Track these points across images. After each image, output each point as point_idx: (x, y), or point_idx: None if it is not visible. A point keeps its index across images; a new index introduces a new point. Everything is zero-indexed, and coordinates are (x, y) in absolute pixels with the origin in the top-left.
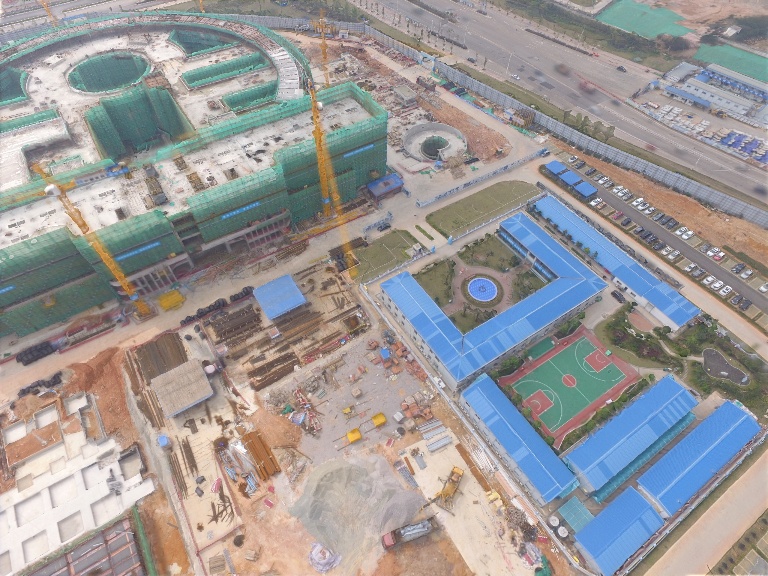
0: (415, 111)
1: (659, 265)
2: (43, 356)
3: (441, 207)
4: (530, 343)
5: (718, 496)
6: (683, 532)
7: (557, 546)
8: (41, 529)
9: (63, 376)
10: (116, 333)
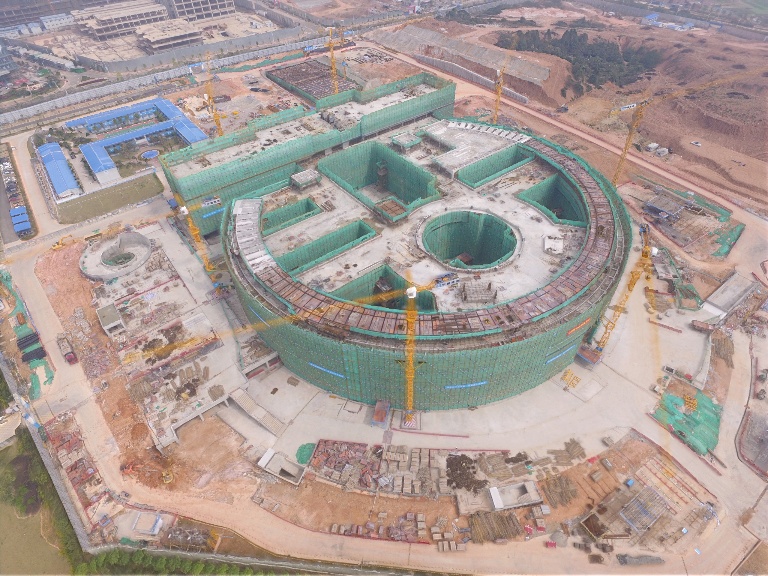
0: None
1: (27, 175)
2: None
3: None
4: None
5: None
6: None
7: None
8: None
9: None
10: None
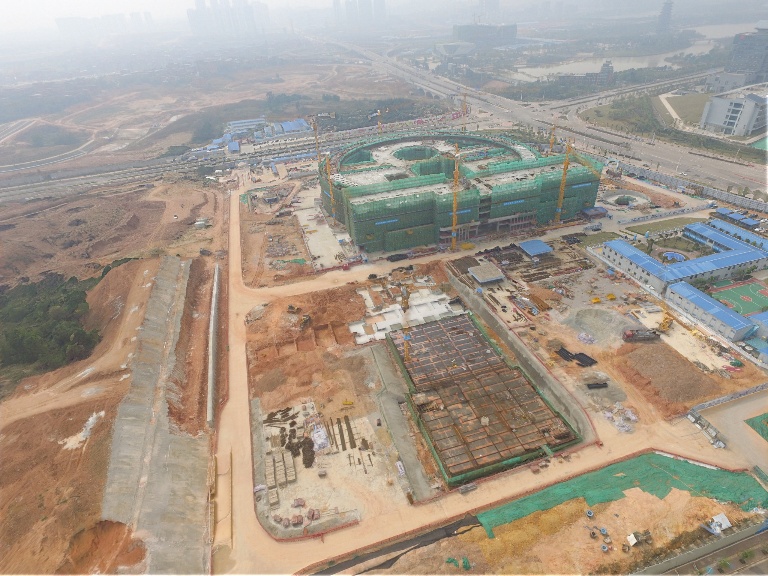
0: (607, 185)
1: None
2: (401, 259)
3: (636, 225)
4: (714, 281)
5: None
6: None
7: (745, 358)
8: (415, 318)
9: (414, 267)
10: (438, 255)
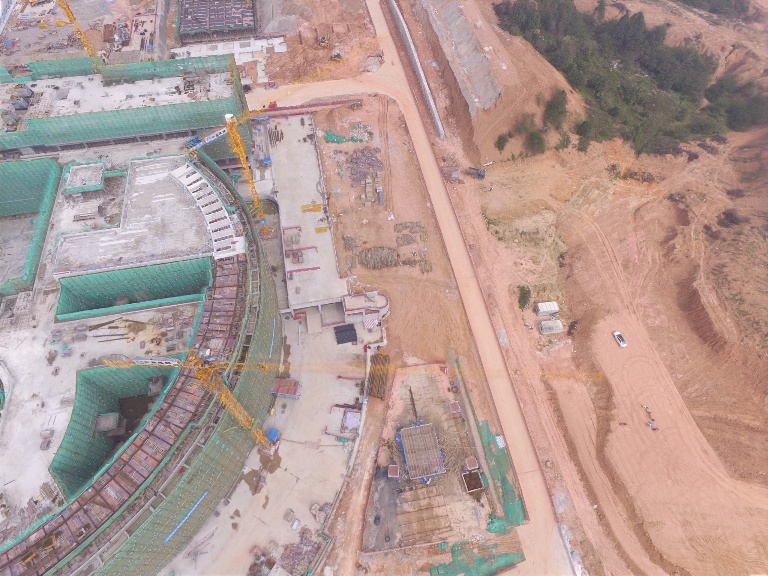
0: None
1: None
2: None
3: None
4: None
5: None
6: None
7: None
8: (225, 50)
9: None
10: None
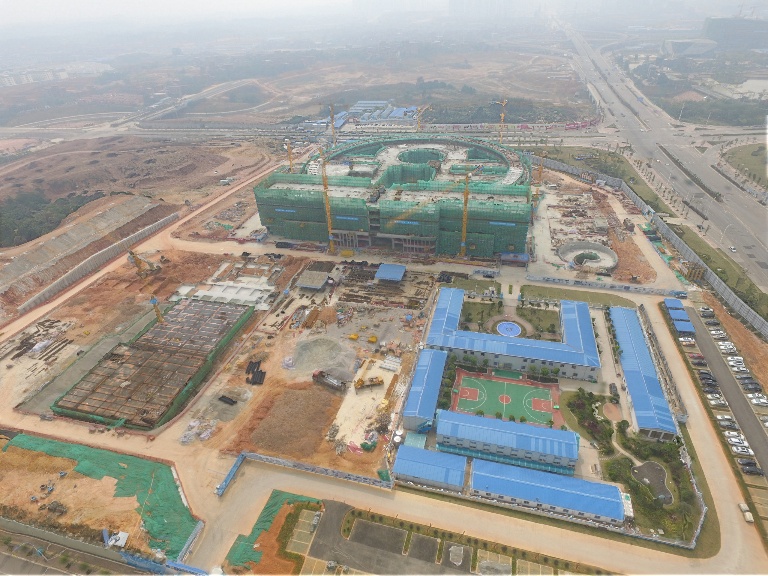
0: (599, 236)
1: (692, 400)
2: (284, 248)
3: (543, 286)
4: (504, 368)
5: (528, 519)
6: (472, 507)
7: None
8: (226, 297)
9: (283, 257)
10: (315, 253)
